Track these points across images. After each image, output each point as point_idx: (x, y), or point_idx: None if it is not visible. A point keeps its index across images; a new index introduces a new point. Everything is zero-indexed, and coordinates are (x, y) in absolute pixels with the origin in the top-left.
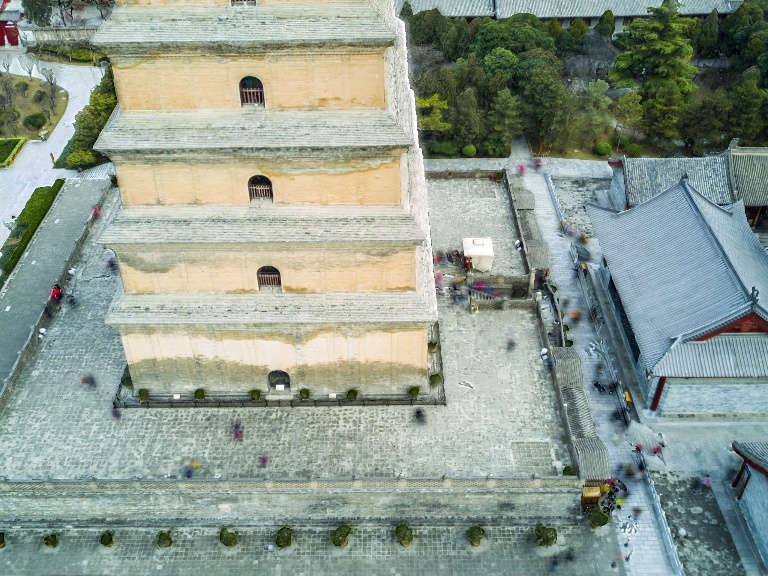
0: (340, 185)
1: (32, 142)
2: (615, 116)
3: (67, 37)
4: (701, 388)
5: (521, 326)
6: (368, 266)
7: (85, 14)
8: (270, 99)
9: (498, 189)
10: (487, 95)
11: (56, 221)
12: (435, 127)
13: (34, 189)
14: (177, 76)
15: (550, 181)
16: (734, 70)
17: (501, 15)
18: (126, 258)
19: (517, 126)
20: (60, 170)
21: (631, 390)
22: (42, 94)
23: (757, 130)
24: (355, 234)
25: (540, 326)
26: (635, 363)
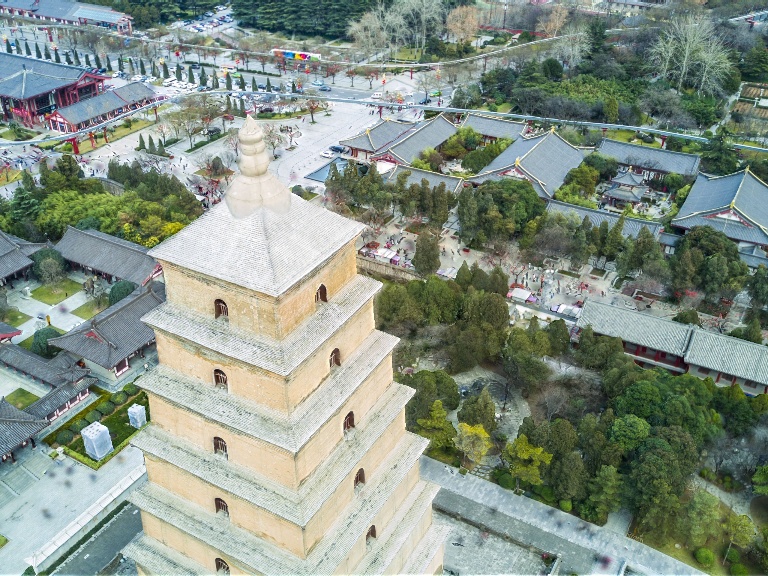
0: None
1: None
2: (754, 516)
3: None
4: None
5: None
6: None
7: None
8: (233, 517)
9: (542, 573)
10: (599, 460)
11: None
12: (527, 479)
13: None
14: (180, 478)
15: (620, 574)
16: None
17: (689, 359)
18: (141, 565)
19: (613, 503)
20: None
21: None
22: None
23: None
24: None
25: None
26: None
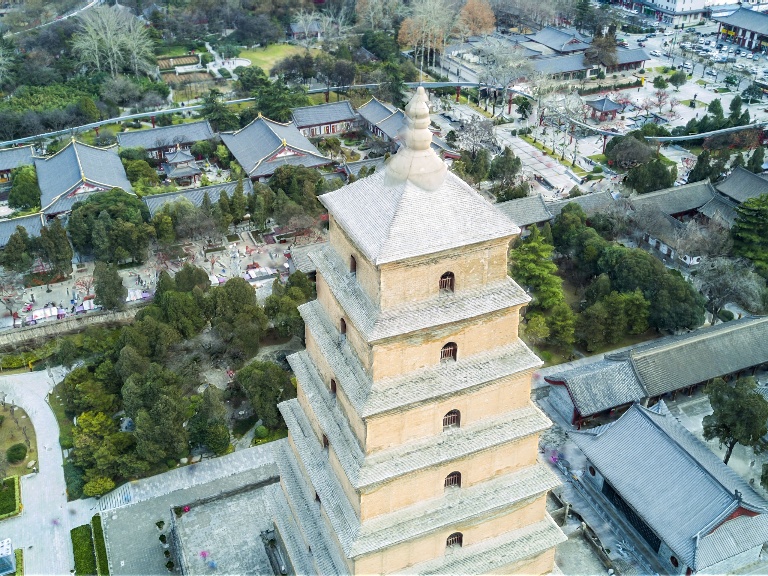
0: (507, 521)
1: (26, 477)
2: None
3: None
4: (714, 564)
5: (581, 554)
6: (525, 568)
7: None
8: (465, 481)
9: None
10: None
11: (122, 563)
12: None
13: (65, 531)
14: (405, 487)
15: None
16: (578, 269)
17: None
18: None
19: None
20: (77, 502)
21: (662, 575)
22: (2, 419)
23: (625, 325)
24: (523, 552)
25: (594, 550)
26: (655, 553)
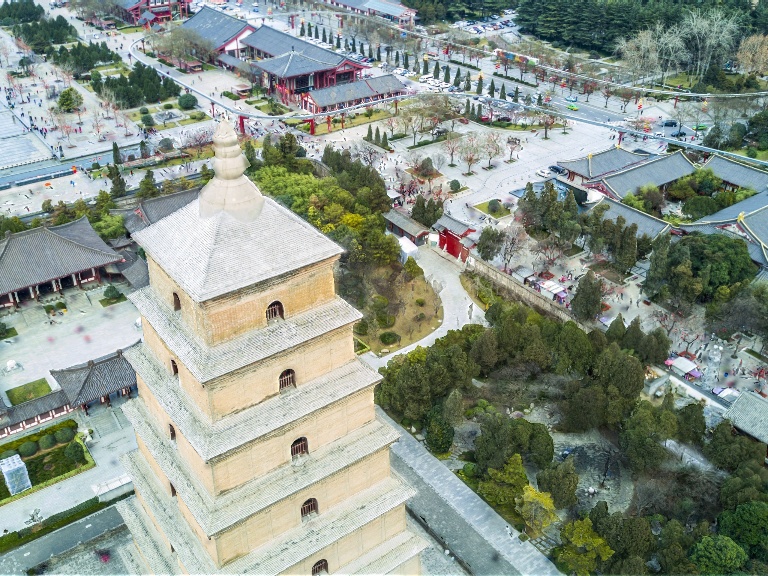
0: None
1: (371, 354)
2: None
3: (494, 275)
4: None
5: None
6: None
7: (523, 263)
8: None
9: None
10: (669, 575)
11: None
12: (574, 568)
13: None
14: None
15: None
16: None
17: None
18: None
19: None
20: None
21: None
22: (421, 317)
23: None
24: None
25: None
26: None
